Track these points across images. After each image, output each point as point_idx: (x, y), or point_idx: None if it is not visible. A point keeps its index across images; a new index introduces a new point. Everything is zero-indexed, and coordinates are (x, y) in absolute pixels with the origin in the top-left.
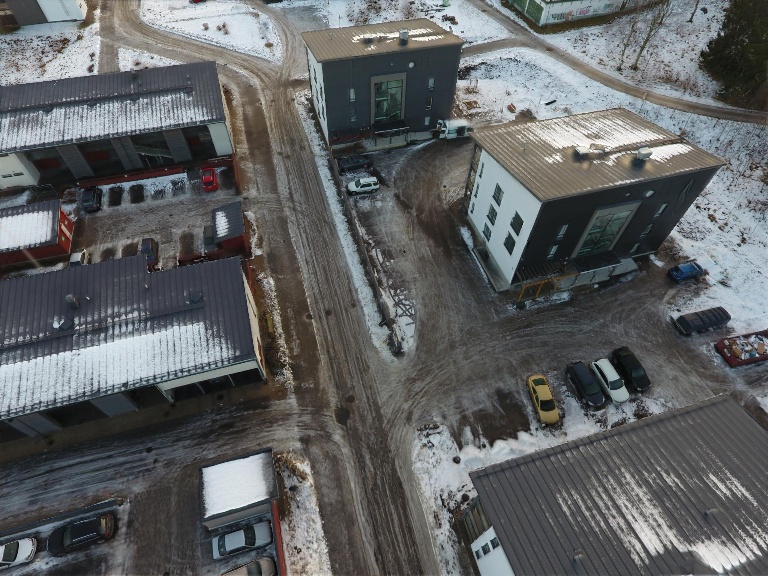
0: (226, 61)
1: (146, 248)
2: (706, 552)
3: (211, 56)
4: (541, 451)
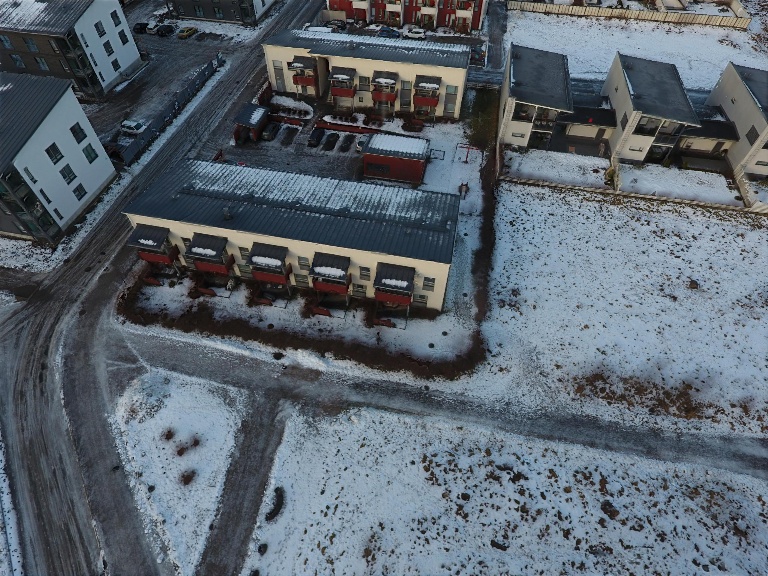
0: (48, 408)
1: (316, 132)
2: None
3: (54, 443)
4: None
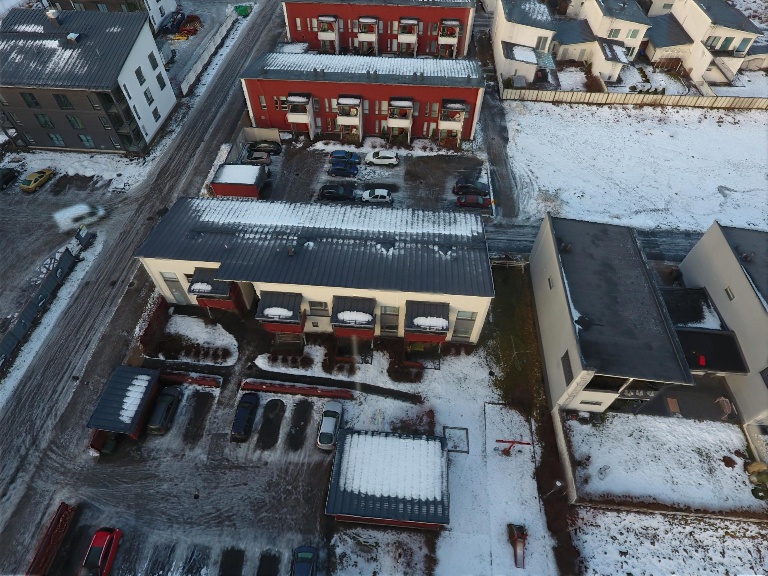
0: None
1: (243, 413)
2: (54, 45)
3: None
4: (70, 88)
